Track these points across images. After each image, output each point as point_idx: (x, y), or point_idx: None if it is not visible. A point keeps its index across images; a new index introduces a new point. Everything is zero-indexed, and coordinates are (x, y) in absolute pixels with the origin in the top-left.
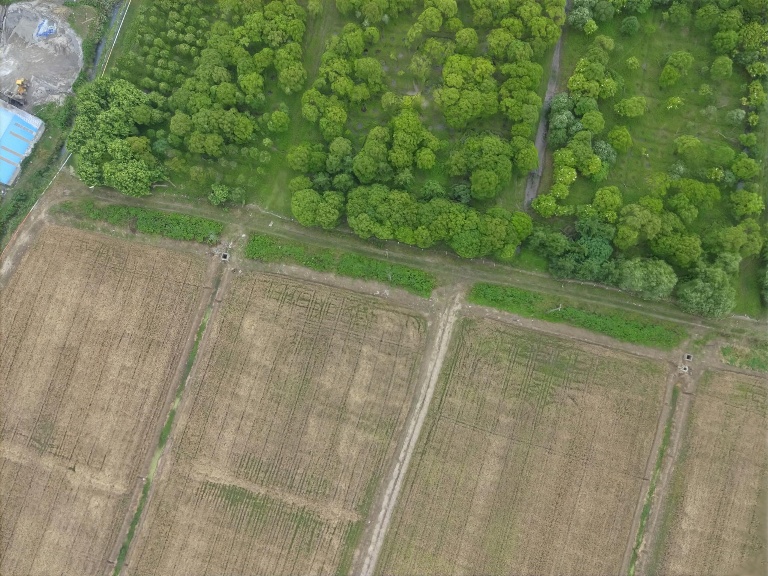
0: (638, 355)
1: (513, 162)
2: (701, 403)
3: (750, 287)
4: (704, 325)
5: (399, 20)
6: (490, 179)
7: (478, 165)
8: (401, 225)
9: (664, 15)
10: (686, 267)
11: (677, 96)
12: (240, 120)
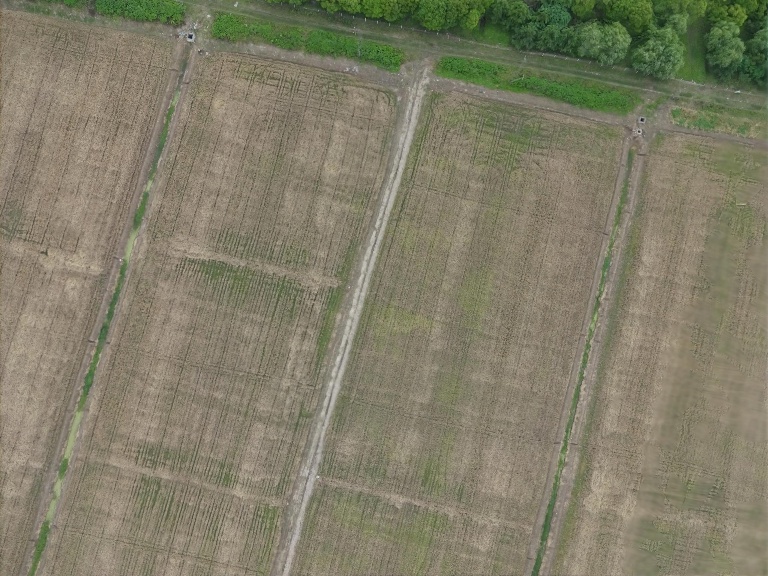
0: (596, 121)
1: None
2: (654, 162)
3: (697, 44)
4: (655, 90)
5: None
6: None
7: None
8: None
9: None
10: (638, 32)
11: None
12: None
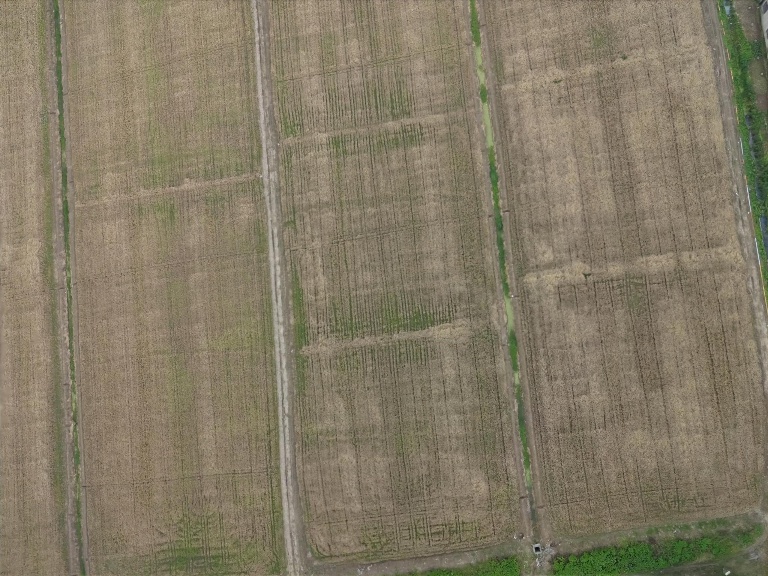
0: None
1: None
2: (59, 573)
3: None
4: None
5: None
6: None
7: None
8: None
9: None
10: None
11: None
12: None
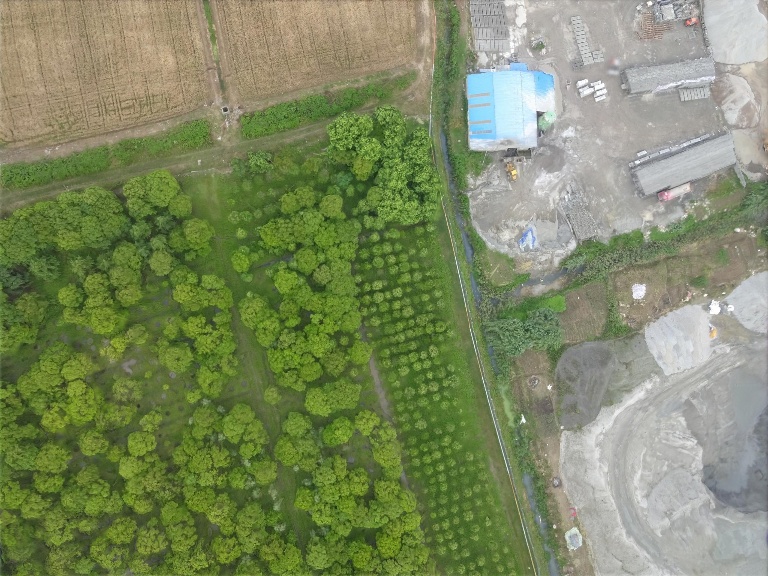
0: None
1: None
2: None
3: None
4: None
5: None
6: None
7: None
8: None
9: None
10: None
11: None
12: (274, 237)
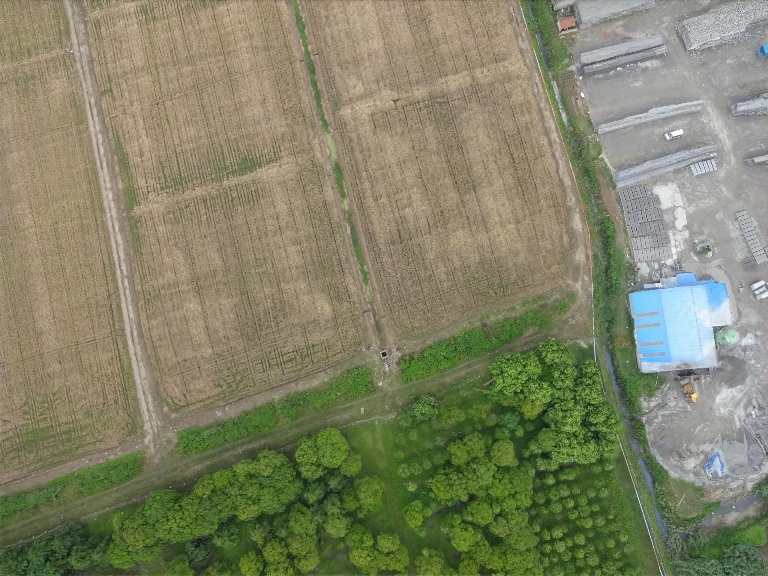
0: None
1: None
2: None
3: None
4: None
5: None
6: None
7: None
8: (228, 485)
9: None
10: None
11: None
12: (447, 493)
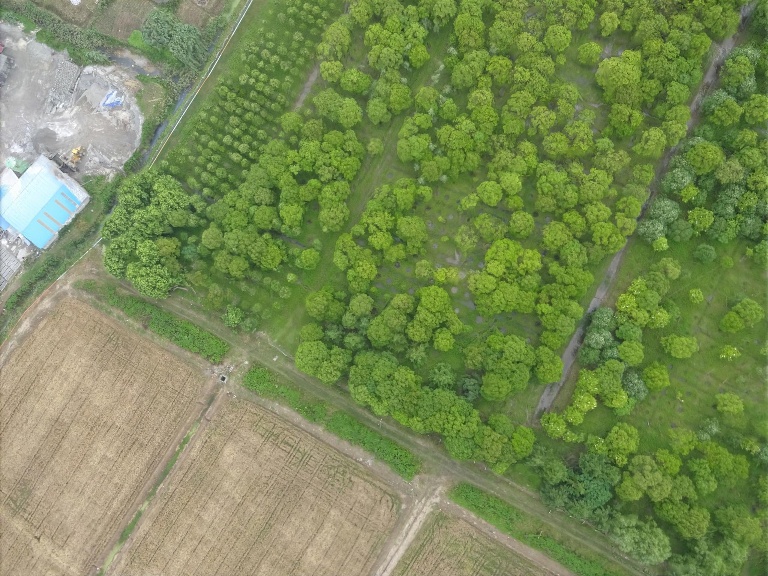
0: None
1: (533, 372)
2: None
3: None
4: None
5: (459, 179)
6: (501, 389)
7: (493, 369)
8: (397, 409)
9: (748, 251)
10: (686, 539)
11: (735, 345)
12: (269, 251)
